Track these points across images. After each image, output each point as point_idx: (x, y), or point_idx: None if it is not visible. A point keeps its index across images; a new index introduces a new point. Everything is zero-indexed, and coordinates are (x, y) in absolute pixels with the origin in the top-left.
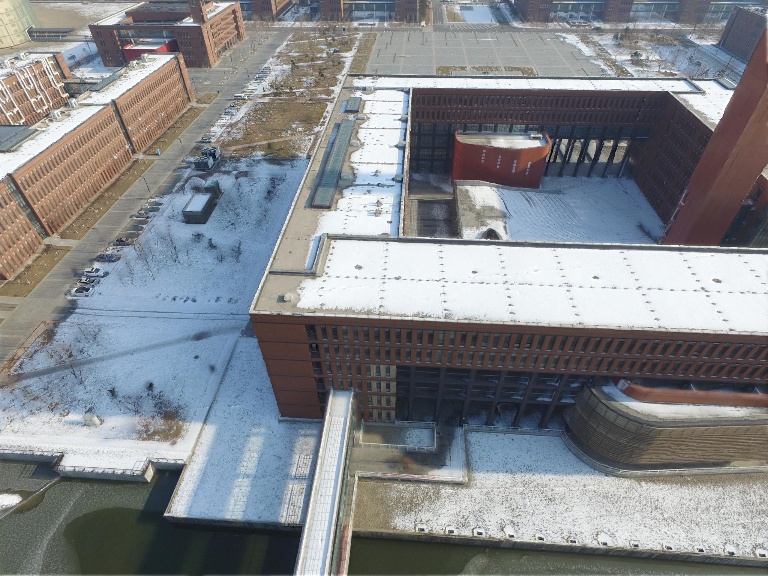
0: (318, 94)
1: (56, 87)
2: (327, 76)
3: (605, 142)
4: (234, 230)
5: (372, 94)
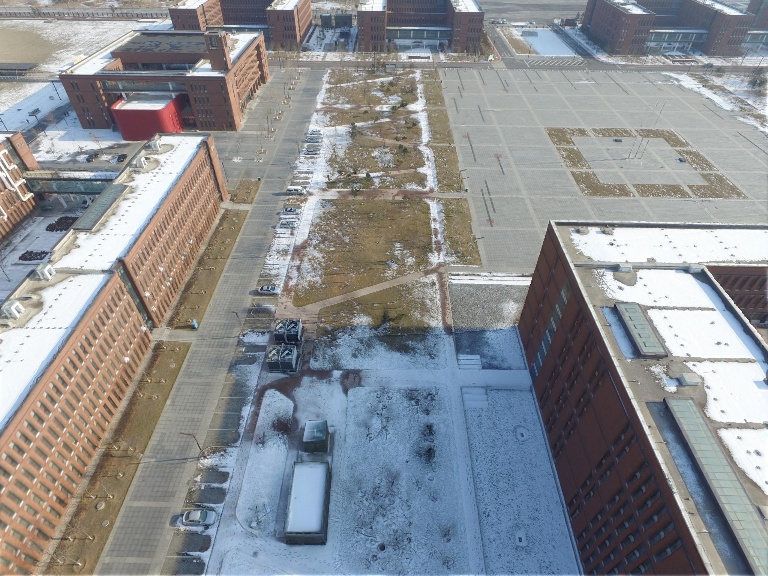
0: (407, 183)
1: (13, 188)
2: (405, 147)
3: None
4: (390, 568)
5: (639, 284)
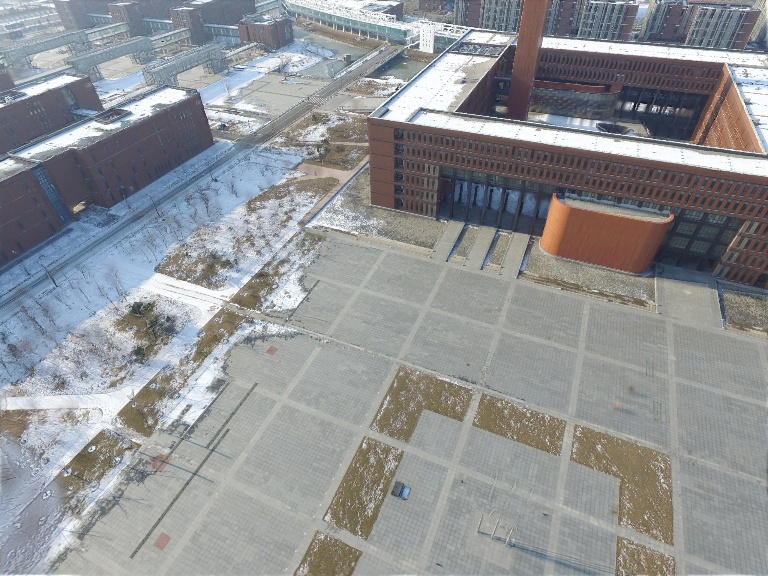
0: None
1: None
2: None
3: (417, 251)
4: None
5: None
